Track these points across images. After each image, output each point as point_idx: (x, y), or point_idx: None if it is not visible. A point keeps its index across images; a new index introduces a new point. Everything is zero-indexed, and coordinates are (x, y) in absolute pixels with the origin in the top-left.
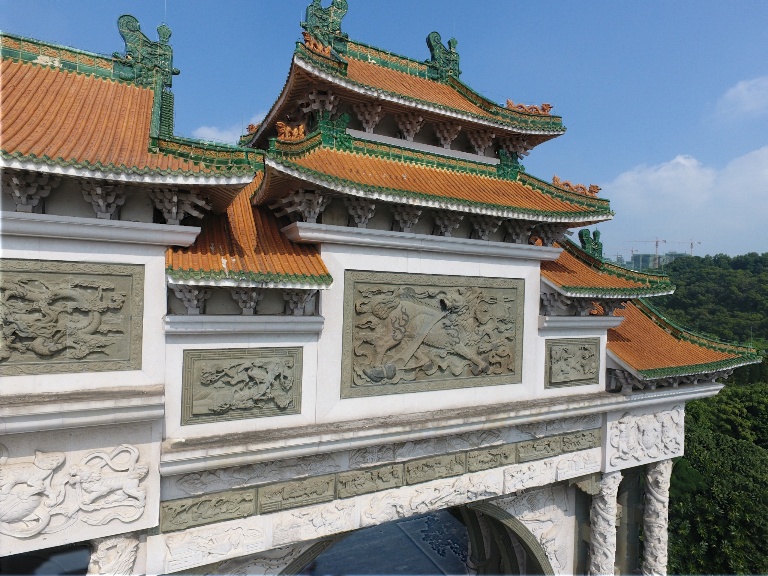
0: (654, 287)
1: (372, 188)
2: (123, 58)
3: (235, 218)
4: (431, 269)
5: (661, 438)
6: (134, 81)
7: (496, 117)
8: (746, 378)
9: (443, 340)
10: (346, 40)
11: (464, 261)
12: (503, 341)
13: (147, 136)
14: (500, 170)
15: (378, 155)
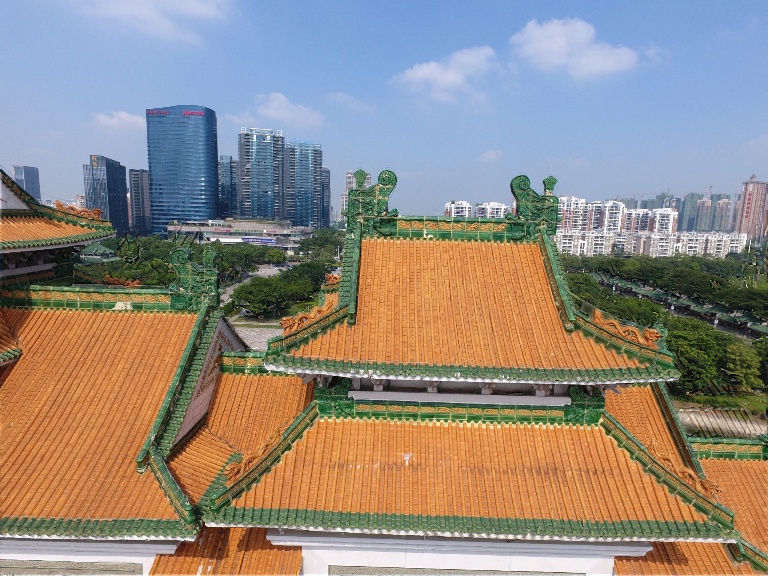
0: None
1: (334, 522)
2: (177, 291)
3: None
4: (438, 564)
5: None
6: (187, 309)
7: (573, 336)
8: None
9: None
10: (395, 219)
11: (486, 554)
12: None
13: None
14: (570, 412)
15: (387, 417)
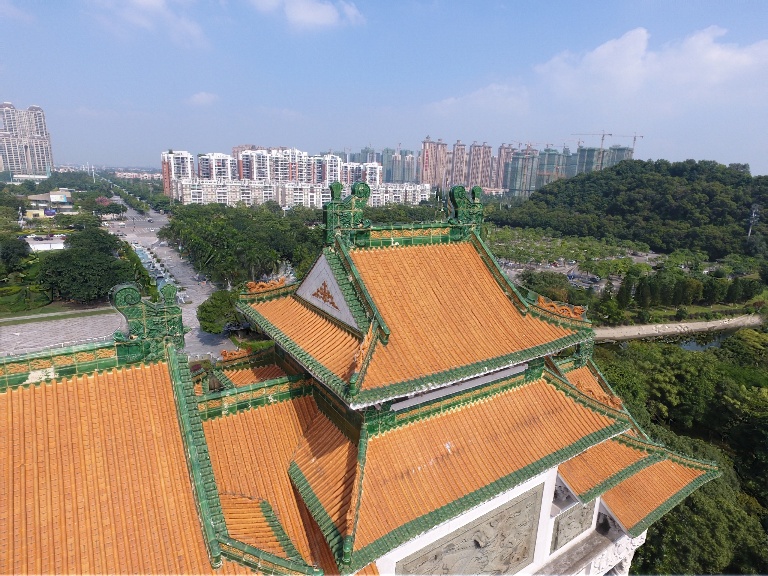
0: (651, 456)
1: (431, 522)
2: (127, 340)
3: (282, 520)
4: (468, 519)
5: (631, 541)
6: (143, 360)
7: (527, 318)
8: (670, 301)
9: (475, 568)
10: (368, 230)
11: None
12: (522, 539)
13: (191, 496)
14: (527, 374)
15: (419, 418)
